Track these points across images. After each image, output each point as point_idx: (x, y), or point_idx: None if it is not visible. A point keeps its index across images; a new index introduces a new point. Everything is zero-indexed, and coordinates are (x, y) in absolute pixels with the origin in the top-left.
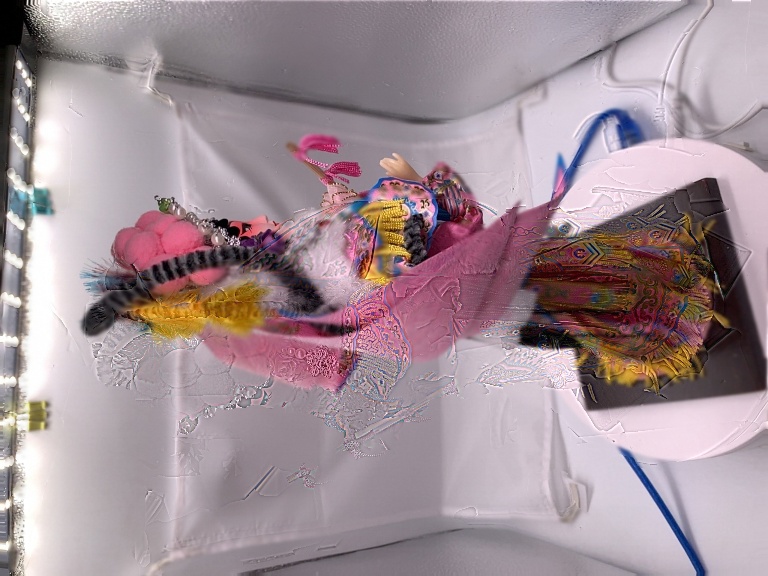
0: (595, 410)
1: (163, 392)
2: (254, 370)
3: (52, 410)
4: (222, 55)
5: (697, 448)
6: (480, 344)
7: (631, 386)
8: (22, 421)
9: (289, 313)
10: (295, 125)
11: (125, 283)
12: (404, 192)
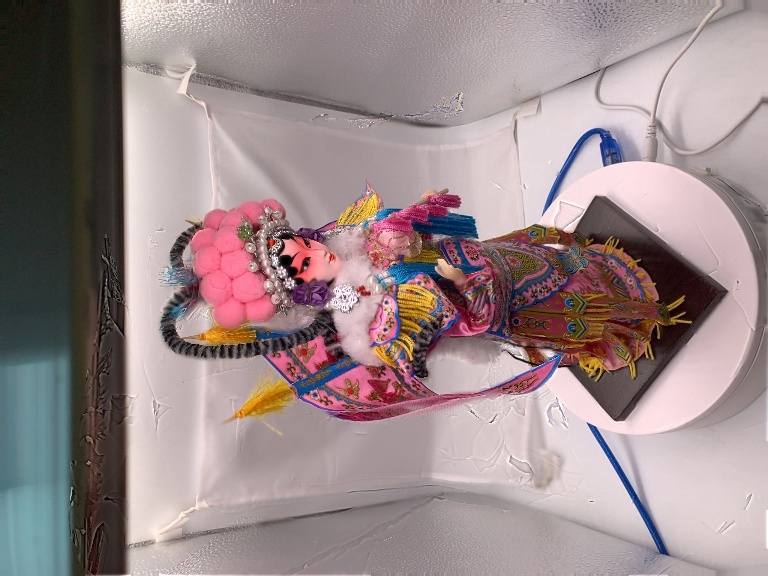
0: (696, 299)
1: (214, 232)
2: None
3: (137, 407)
4: (258, 569)
5: (707, 195)
6: None
7: (657, 261)
8: (103, 406)
9: None
10: (351, 564)
11: (164, 227)
12: None
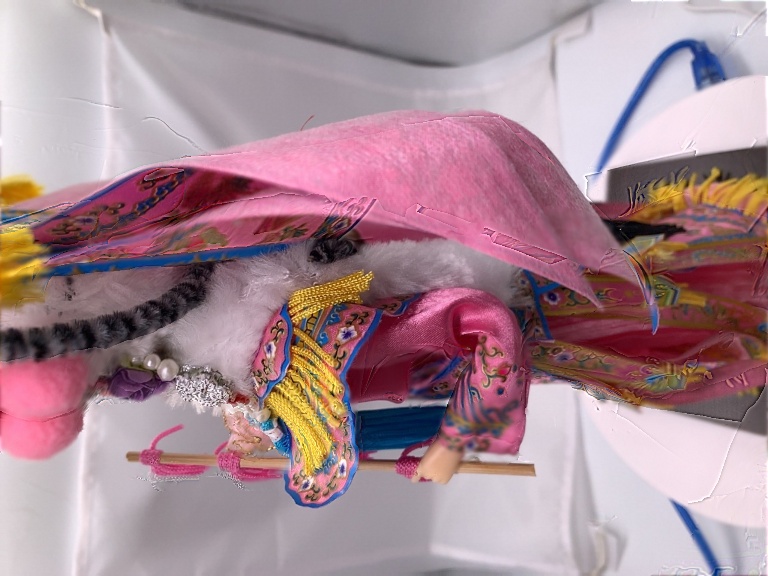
0: None
1: None
2: (39, 446)
3: None
4: None
5: (688, 493)
6: (485, 432)
7: None
8: None
9: (148, 332)
10: None
11: None
12: (475, 209)
